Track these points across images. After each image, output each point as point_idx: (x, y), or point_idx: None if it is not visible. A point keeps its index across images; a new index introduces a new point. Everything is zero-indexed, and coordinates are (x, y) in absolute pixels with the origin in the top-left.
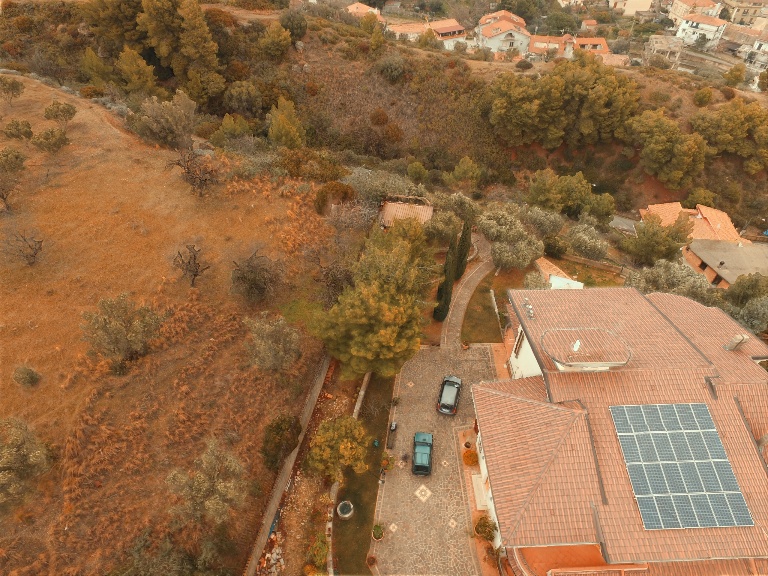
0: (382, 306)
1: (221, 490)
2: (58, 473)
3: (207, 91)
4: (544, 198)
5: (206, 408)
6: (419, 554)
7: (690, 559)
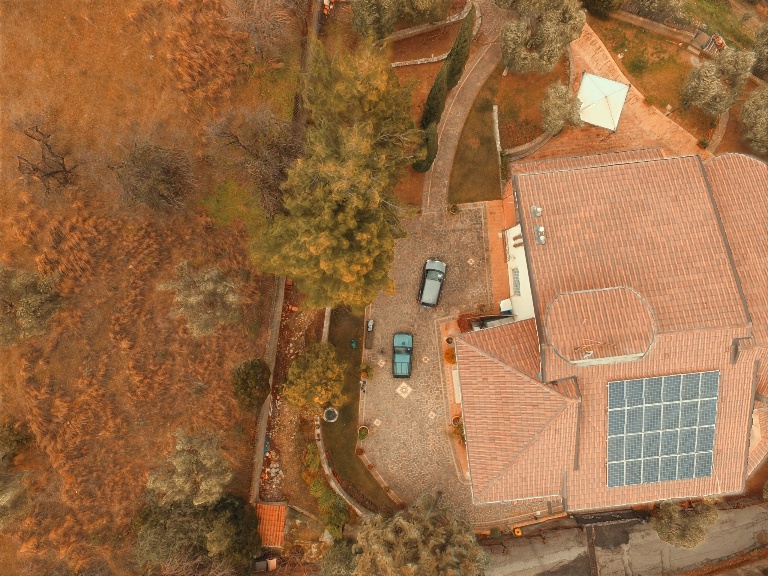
0: (338, 267)
1: (204, 488)
2: (39, 452)
3: None
4: None
5: (159, 359)
6: (401, 442)
7: (639, 502)
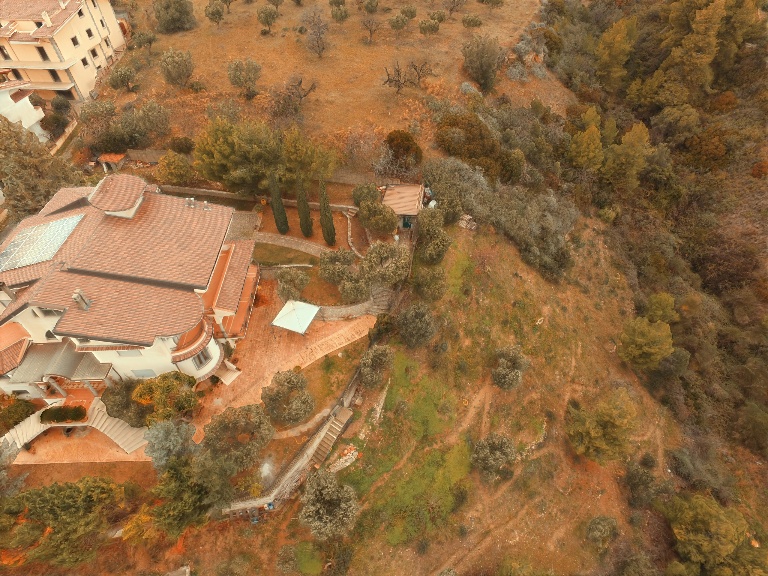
0: None
1: None
2: None
3: (656, 96)
4: (585, 415)
5: None
6: None
7: None
